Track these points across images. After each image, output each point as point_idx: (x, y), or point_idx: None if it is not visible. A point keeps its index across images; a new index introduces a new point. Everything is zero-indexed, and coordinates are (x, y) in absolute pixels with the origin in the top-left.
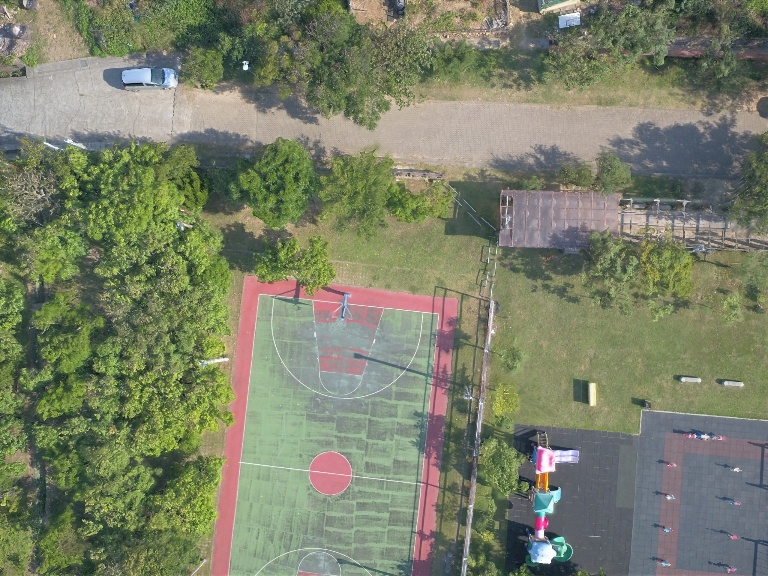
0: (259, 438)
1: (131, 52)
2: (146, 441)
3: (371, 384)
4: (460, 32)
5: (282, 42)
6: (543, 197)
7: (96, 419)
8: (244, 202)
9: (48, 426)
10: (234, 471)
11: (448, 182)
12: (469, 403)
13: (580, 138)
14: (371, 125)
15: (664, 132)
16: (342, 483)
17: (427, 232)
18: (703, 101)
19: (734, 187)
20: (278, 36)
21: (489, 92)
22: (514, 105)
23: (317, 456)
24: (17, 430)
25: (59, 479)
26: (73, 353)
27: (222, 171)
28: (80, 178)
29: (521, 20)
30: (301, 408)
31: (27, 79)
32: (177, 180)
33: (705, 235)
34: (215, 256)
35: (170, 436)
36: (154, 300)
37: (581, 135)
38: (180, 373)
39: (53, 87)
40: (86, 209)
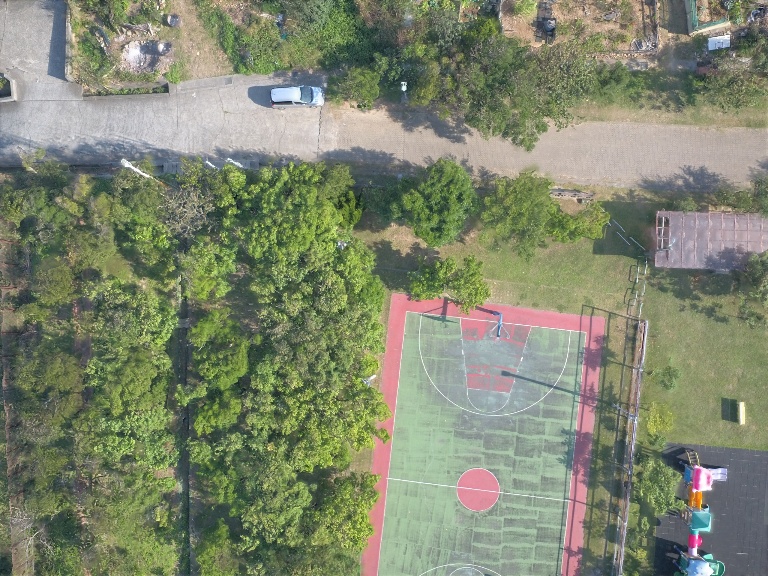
0: (407, 454)
1: (277, 70)
2: (304, 458)
3: (519, 401)
4: (608, 53)
5: (444, 64)
6: (699, 218)
7: (252, 435)
8: (392, 220)
9: (202, 442)
10: (381, 487)
11: (597, 202)
12: (617, 421)
13: (729, 159)
14: (530, 146)
15: None
16: (490, 499)
17: (575, 251)
18: None
19: None
20: (437, 57)
21: (638, 113)
22: (663, 126)
23: (465, 472)
24: (170, 446)
25: (219, 495)
26: (231, 370)
27: (378, 190)
28: (237, 196)
29: (669, 42)
30: (449, 425)
31: (170, 96)
32: (334, 199)
33: None
34: (370, 274)
35: (327, 453)
36: (312, 318)
37: (730, 156)
38: (336, 390)
39: (196, 104)
40: (248, 228)
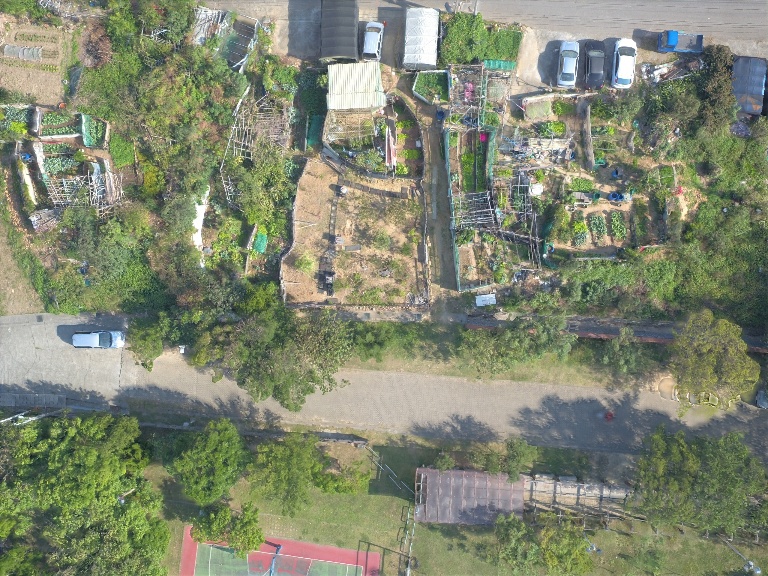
0: None
1: (82, 311)
2: None
3: None
4: (385, 306)
5: (214, 334)
6: (455, 476)
7: None
8: None
9: None
10: None
11: (372, 446)
12: None
13: (494, 410)
14: (296, 408)
15: (572, 407)
16: None
17: None
18: (609, 379)
19: (636, 461)
20: (212, 324)
21: (411, 363)
22: (434, 377)
23: None
24: None
25: None
26: None
27: (161, 443)
28: None
29: (441, 296)
30: None
31: None
32: (119, 451)
33: (608, 504)
34: (155, 519)
35: None
36: (98, 562)
37: (495, 407)
38: None
39: (11, 339)
40: (35, 483)
